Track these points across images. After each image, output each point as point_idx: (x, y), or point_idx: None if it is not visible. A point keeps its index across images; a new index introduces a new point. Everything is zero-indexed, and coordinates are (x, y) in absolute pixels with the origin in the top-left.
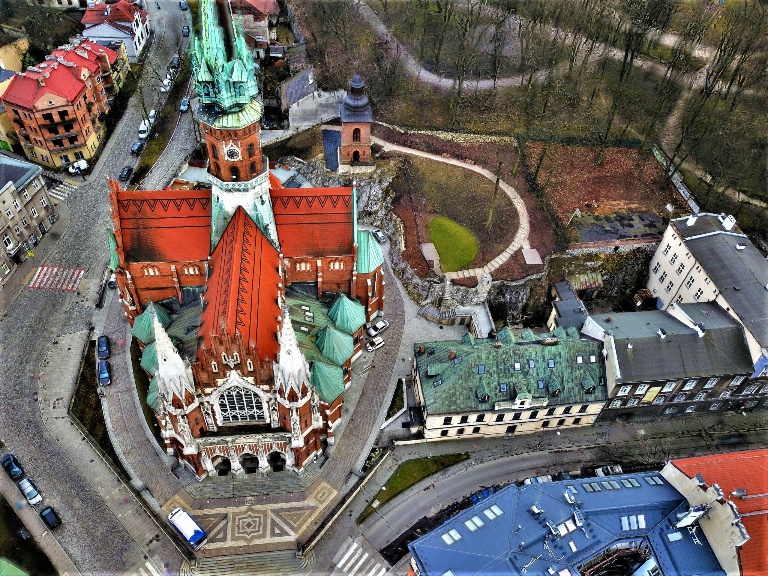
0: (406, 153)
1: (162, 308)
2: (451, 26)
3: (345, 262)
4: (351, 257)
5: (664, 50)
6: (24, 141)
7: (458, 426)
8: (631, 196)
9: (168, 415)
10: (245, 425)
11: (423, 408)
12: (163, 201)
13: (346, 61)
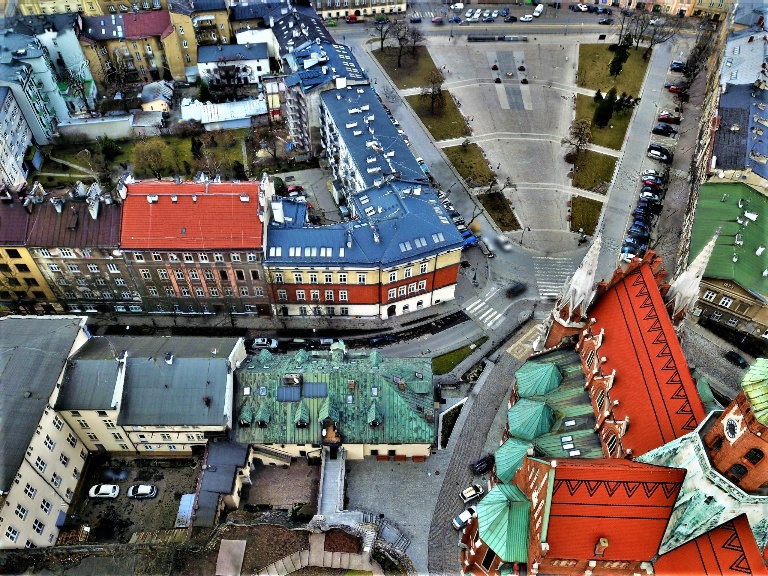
0: None
1: None
2: None
3: None
4: None
5: None
6: None
7: None
8: None
9: None
10: None
11: None
12: None
13: None
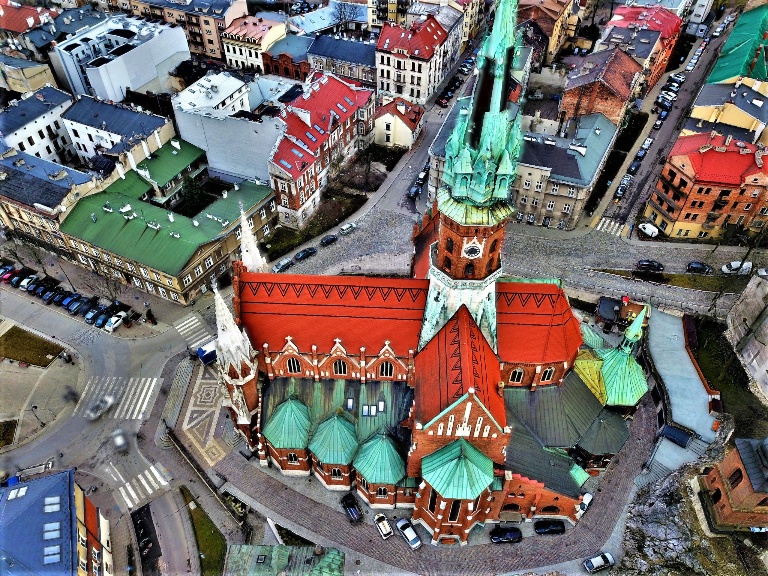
0: None
1: None
2: None
3: None
4: None
5: None
6: None
7: None
8: None
9: None
10: None
11: None
12: None
13: None
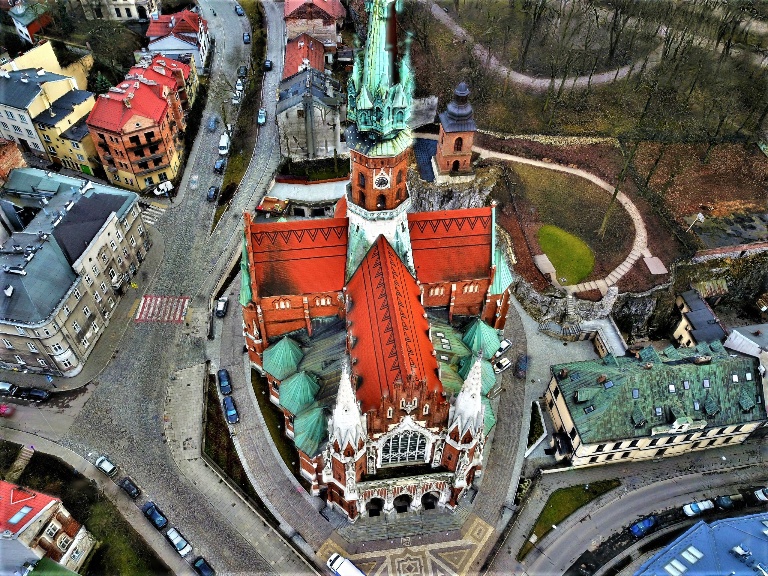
0: (505, 160)
1: (294, 342)
2: (540, 23)
3: (480, 285)
4: (487, 280)
5: (762, 37)
6: (107, 165)
7: (609, 452)
8: (745, 195)
9: (331, 461)
10: (404, 466)
11: (570, 435)
12: (297, 232)
13: (425, 64)
